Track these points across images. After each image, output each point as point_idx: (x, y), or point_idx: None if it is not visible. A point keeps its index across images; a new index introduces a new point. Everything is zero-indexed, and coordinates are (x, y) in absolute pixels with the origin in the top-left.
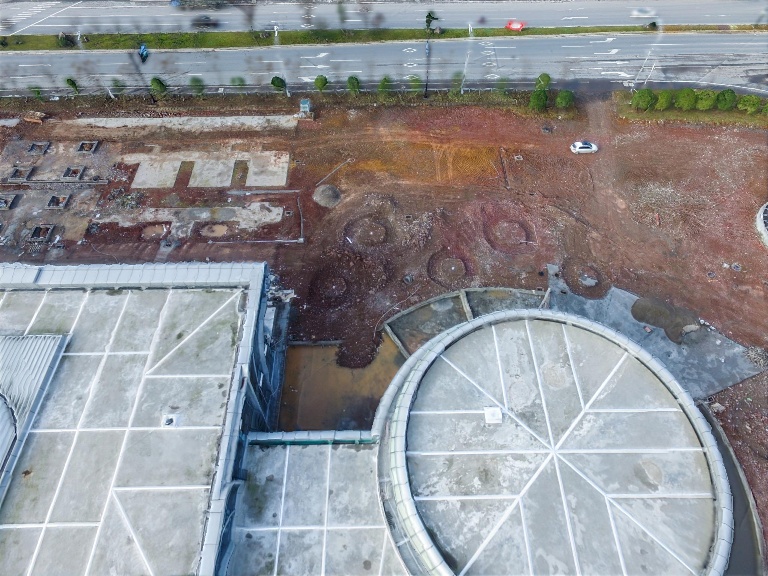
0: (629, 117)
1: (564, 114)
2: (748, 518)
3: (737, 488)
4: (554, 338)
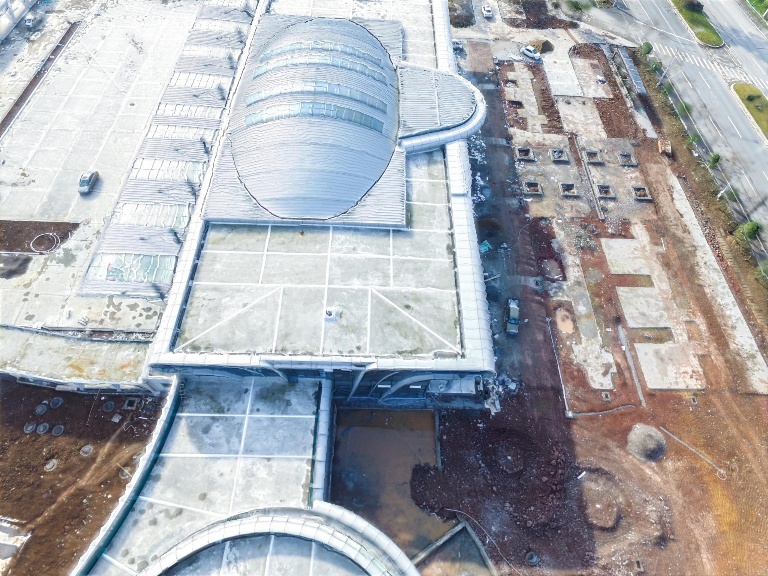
0: None
1: None
2: None
3: None
4: None
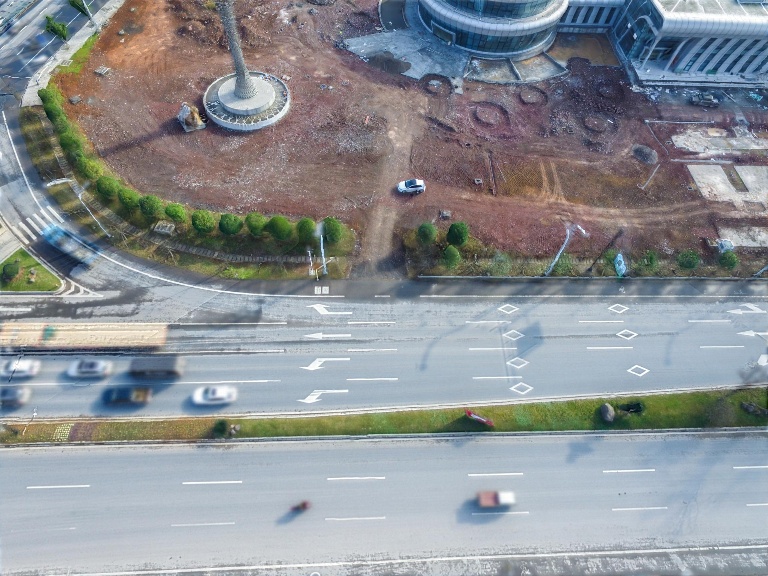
0: (346, 229)
1: None
2: (384, 1)
3: (384, 8)
4: None
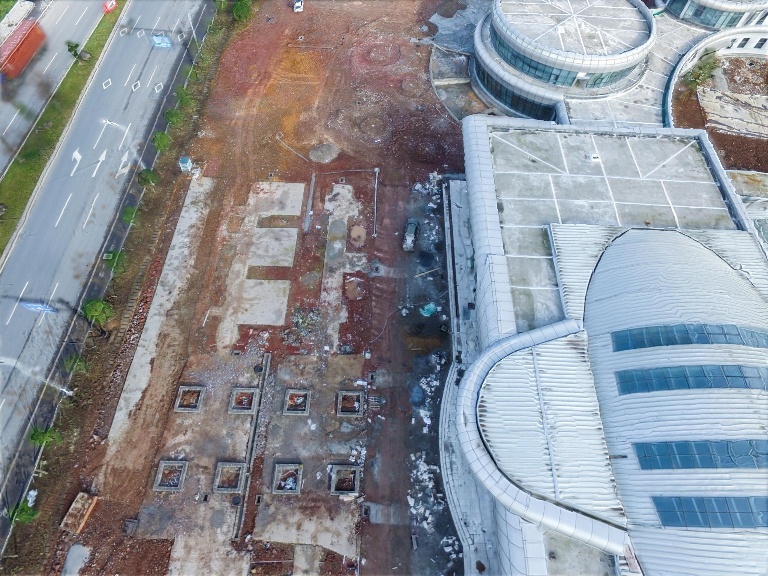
0: None
1: (253, 7)
2: None
3: None
4: (510, 6)
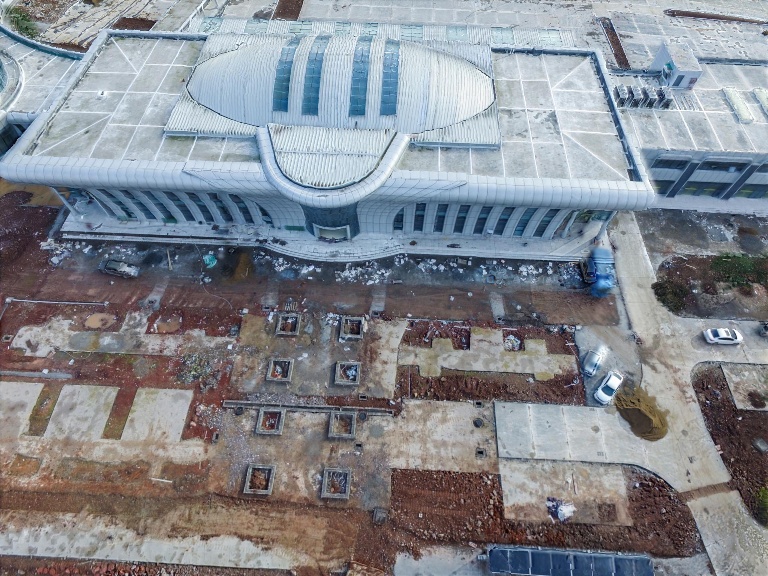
0: None
1: None
2: None
3: None
4: None
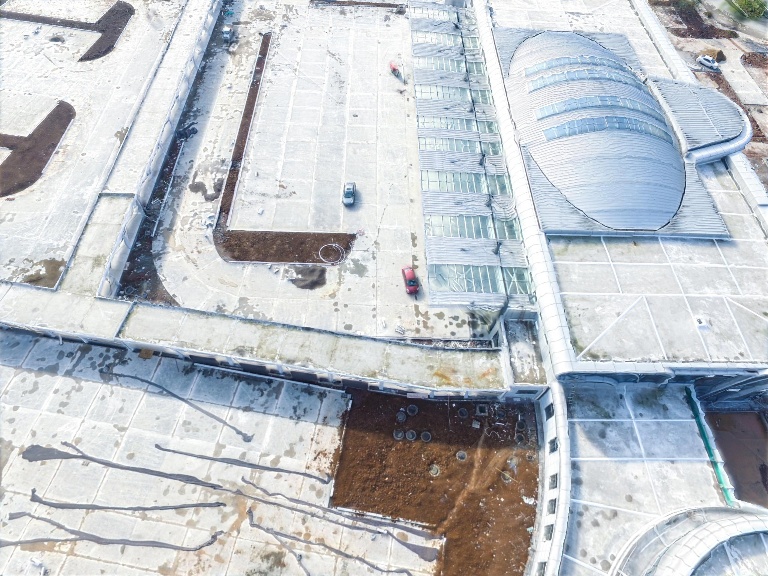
0: None
1: None
2: None
3: None
4: None
